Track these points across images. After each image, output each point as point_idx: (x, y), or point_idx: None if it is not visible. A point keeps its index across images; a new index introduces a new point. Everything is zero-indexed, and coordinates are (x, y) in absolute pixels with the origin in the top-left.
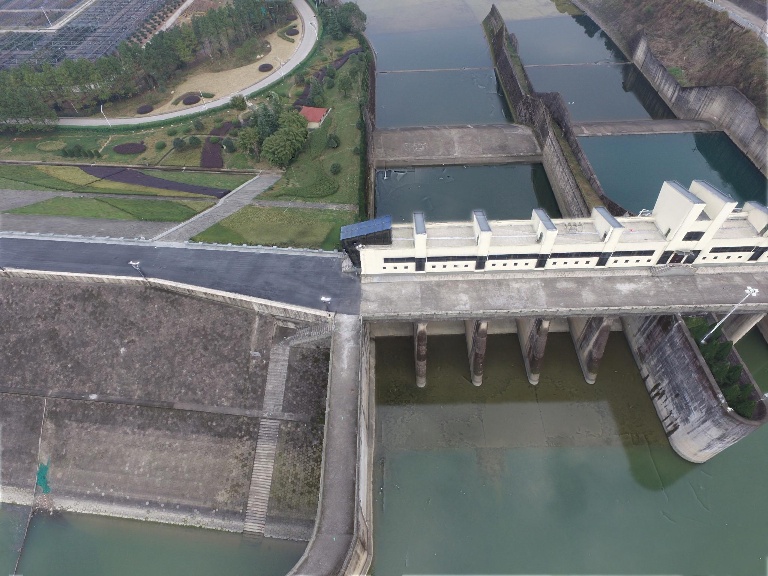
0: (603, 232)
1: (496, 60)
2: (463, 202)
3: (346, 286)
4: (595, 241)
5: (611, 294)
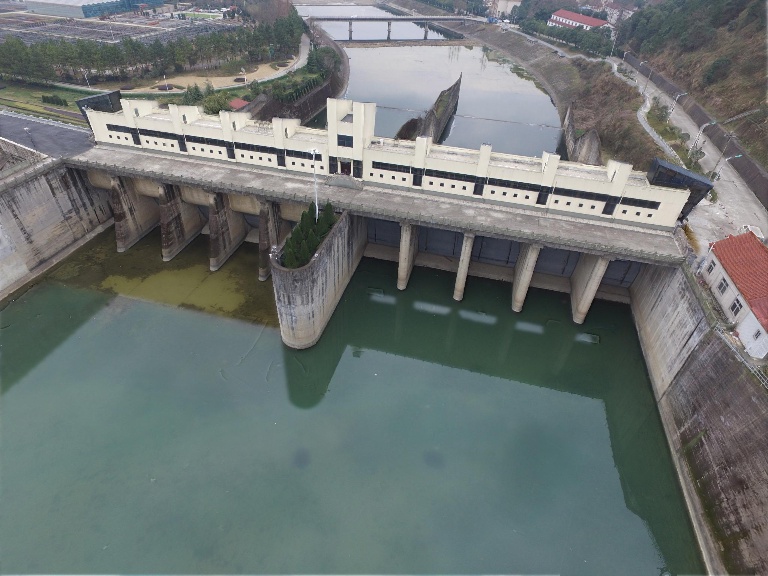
0: None
1: None
2: None
3: (80, 147)
4: None
5: (275, 186)
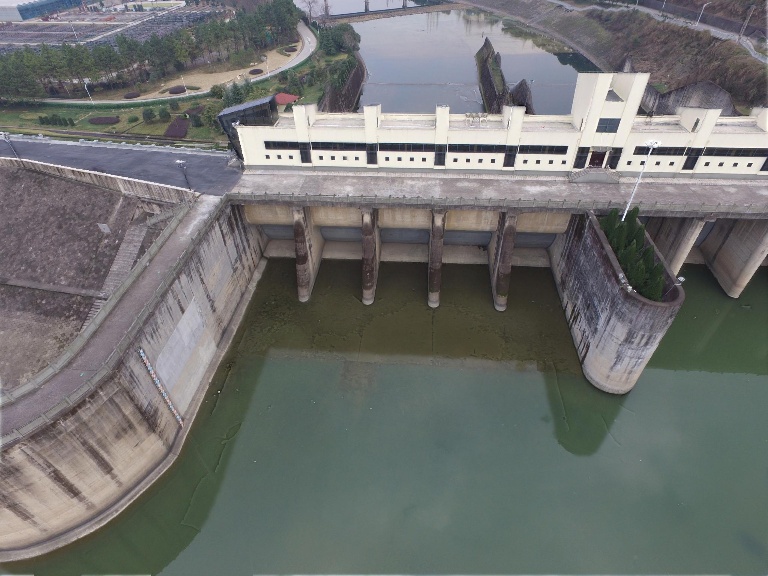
0: (507, 122)
1: (481, 77)
2: None
3: (226, 176)
4: None
5: (516, 193)
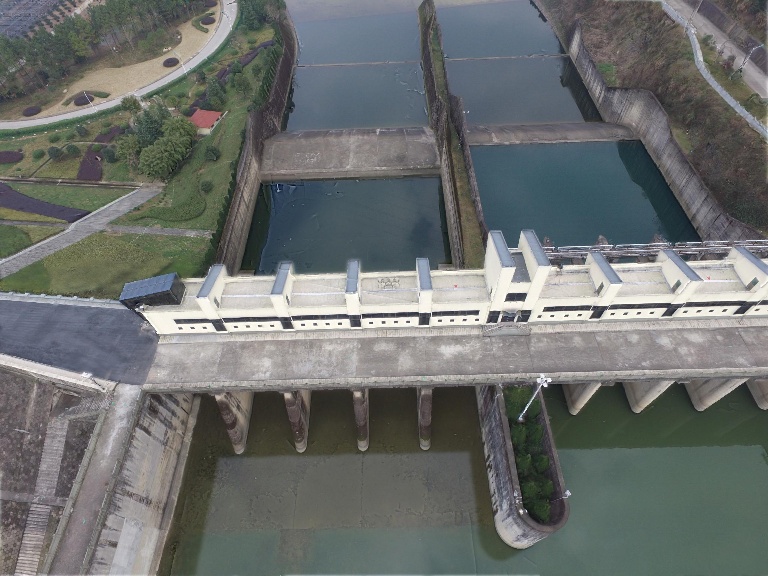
0: None
1: (423, 53)
2: (347, 222)
3: (140, 348)
4: (411, 300)
5: (431, 359)
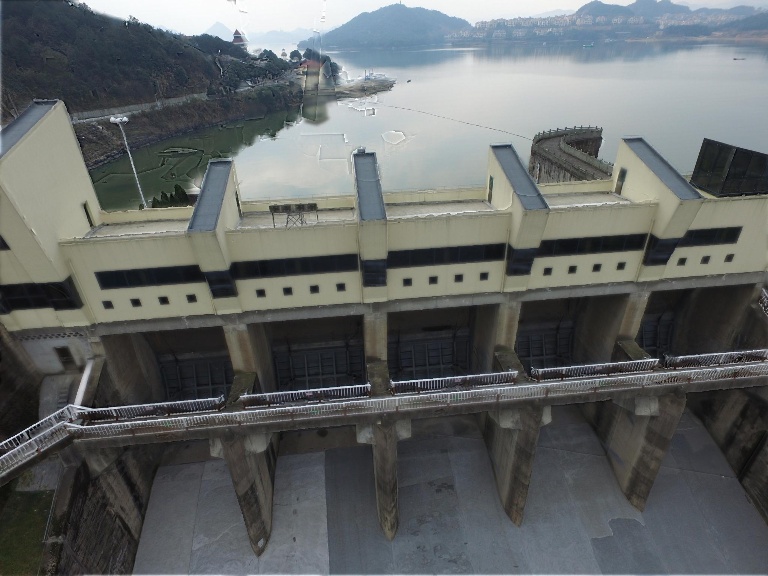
0: None
1: None
2: None
3: None
4: (257, 217)
5: None
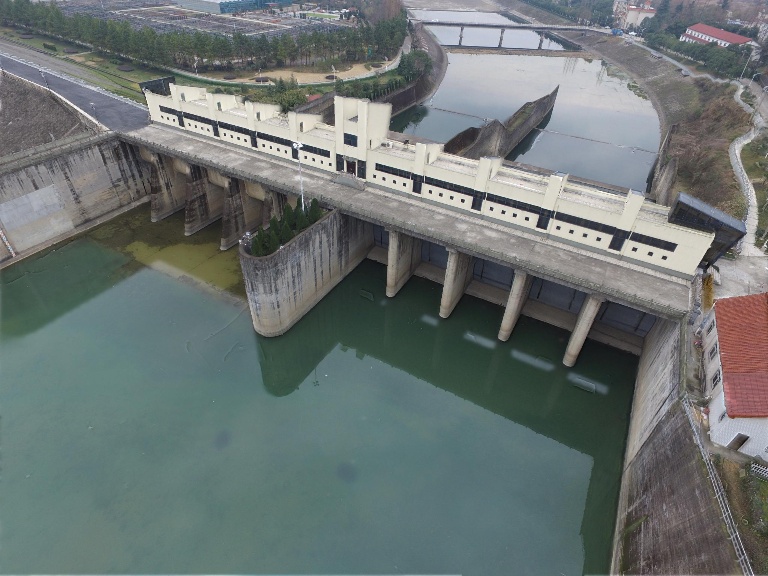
0: None
1: None
2: None
3: (138, 124)
4: None
5: (283, 177)
